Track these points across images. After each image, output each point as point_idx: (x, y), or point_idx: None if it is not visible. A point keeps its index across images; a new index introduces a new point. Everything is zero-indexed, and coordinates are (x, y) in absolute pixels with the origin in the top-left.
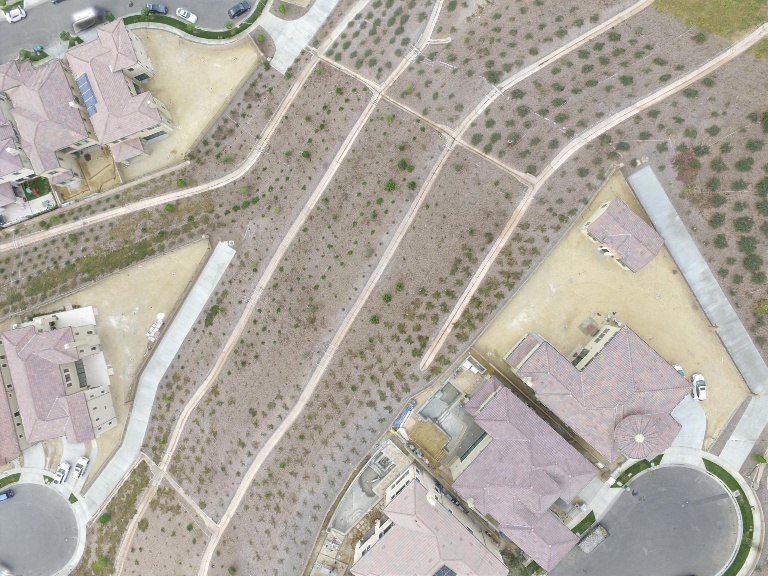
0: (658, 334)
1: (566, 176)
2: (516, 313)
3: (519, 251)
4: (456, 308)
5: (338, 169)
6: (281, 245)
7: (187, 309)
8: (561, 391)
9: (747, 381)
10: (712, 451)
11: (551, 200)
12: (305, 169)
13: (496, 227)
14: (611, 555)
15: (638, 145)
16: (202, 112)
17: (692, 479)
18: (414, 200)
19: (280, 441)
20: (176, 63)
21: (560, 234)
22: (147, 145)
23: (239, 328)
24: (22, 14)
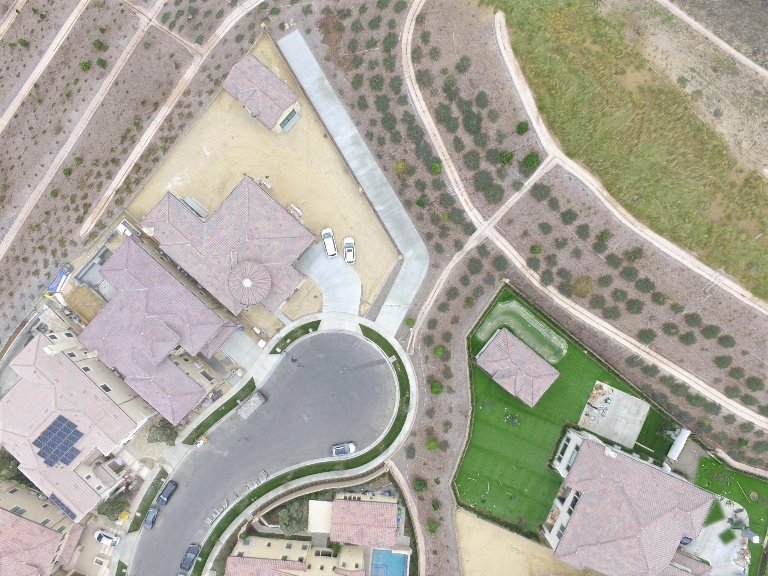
0: (311, 198)
1: (227, 43)
2: (170, 177)
3: (178, 117)
4: (120, 175)
5: (53, 57)
6: None
7: None
8: (181, 240)
9: (398, 245)
10: (368, 316)
11: (212, 67)
12: (23, 58)
13: (163, 96)
14: (271, 422)
15: (287, 9)
16: None
17: (349, 345)
18: (106, 79)
19: None
20: None
21: (212, 97)
22: None
23: None
24: None
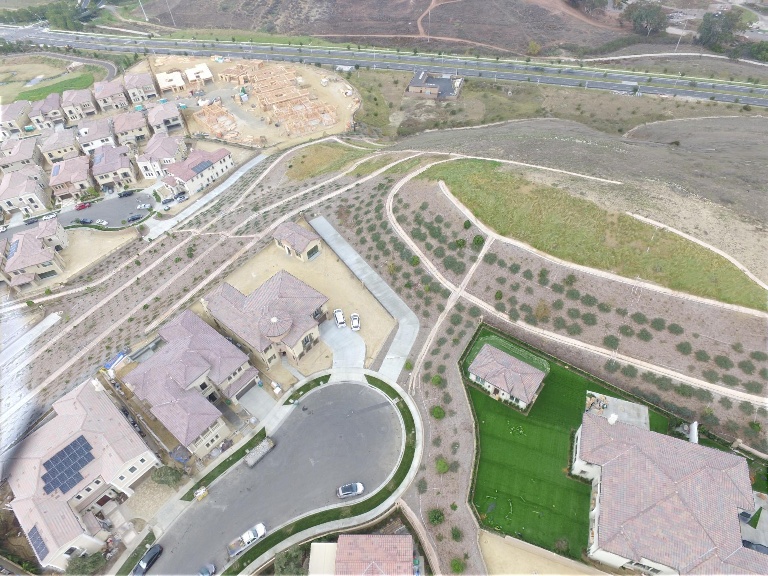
0: (326, 294)
1: None
2: None
3: None
4: (187, 297)
5: None
6: (95, 307)
7: (0, 358)
8: (227, 306)
9: (394, 316)
10: (372, 368)
11: (265, 239)
12: None
13: None
14: (277, 469)
15: None
16: (88, 263)
17: (356, 392)
18: (190, 263)
19: (9, 416)
20: (84, 243)
21: None
22: (40, 281)
23: (32, 359)
24: (3, 229)
